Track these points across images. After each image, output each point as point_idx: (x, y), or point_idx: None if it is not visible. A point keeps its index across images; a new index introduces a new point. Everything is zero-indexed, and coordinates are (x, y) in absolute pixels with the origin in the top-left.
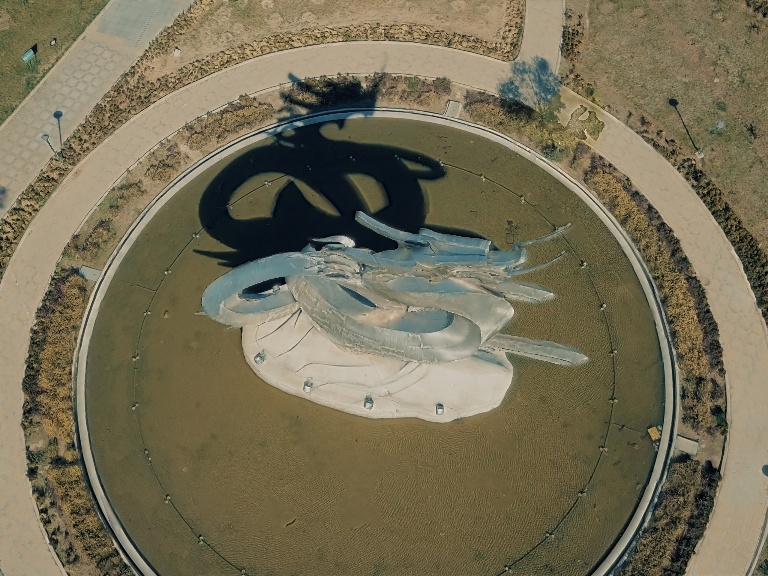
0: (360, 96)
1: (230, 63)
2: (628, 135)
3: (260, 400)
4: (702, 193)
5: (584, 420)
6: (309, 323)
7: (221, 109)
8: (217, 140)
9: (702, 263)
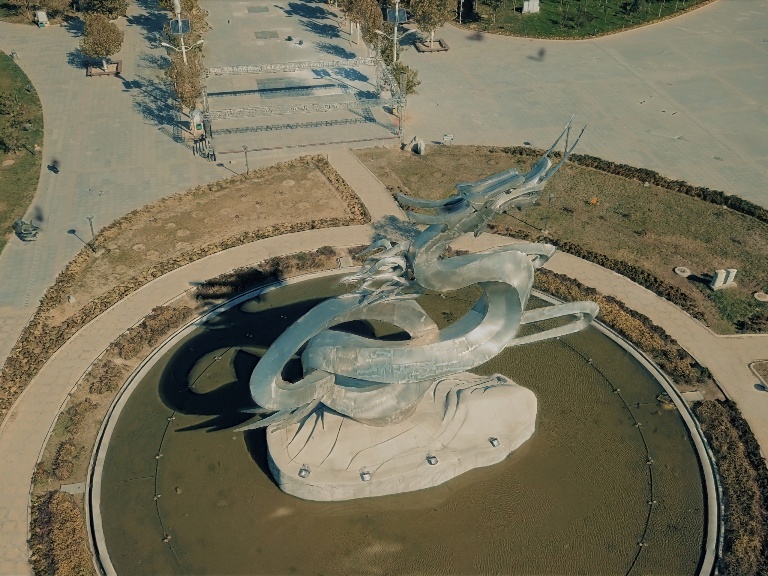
0: (263, 276)
1: (129, 291)
2: (488, 237)
3: (319, 523)
4: (566, 250)
5: (607, 413)
6: (336, 421)
7: (139, 323)
8: (149, 344)
9: (601, 287)
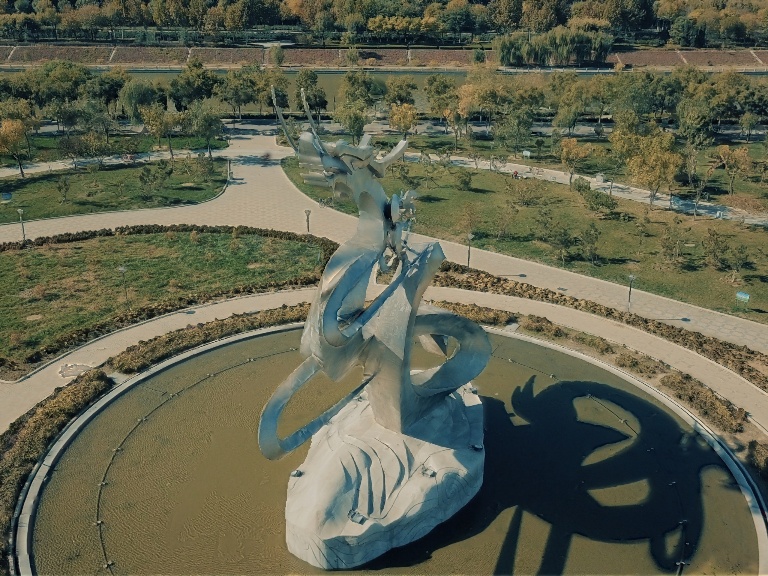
0: None
1: None
2: None
3: None
4: None
5: None
6: None
7: (723, 399)
8: None
9: None
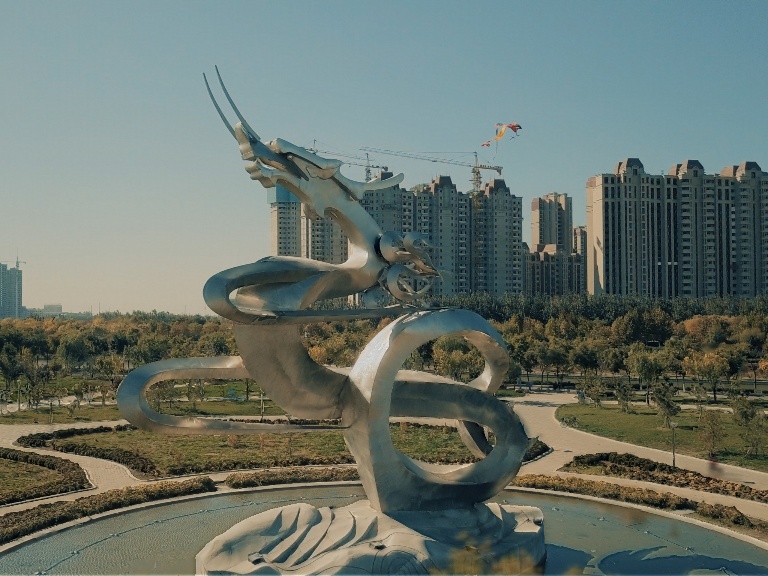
0: None
1: None
2: None
3: None
4: None
5: None
6: None
7: None
8: None
9: None
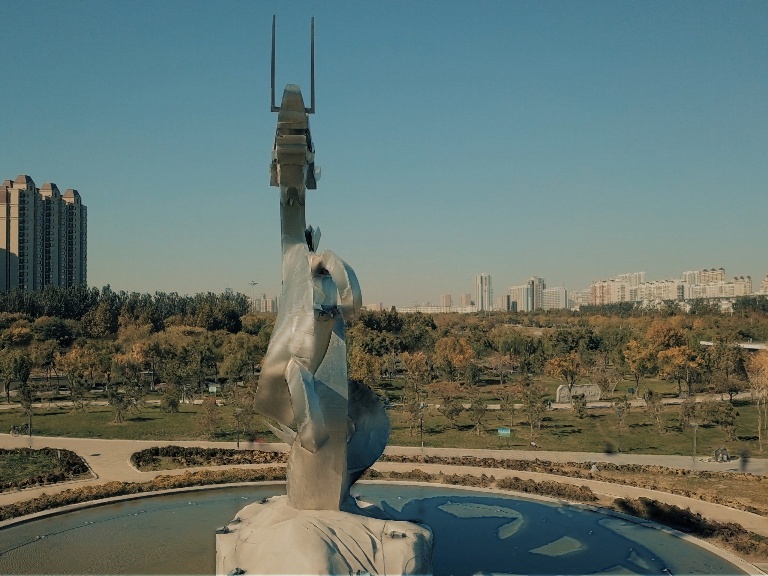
0: (682, 520)
1: (617, 481)
2: None
3: None
4: None
5: None
6: None
7: None
8: None
9: None
